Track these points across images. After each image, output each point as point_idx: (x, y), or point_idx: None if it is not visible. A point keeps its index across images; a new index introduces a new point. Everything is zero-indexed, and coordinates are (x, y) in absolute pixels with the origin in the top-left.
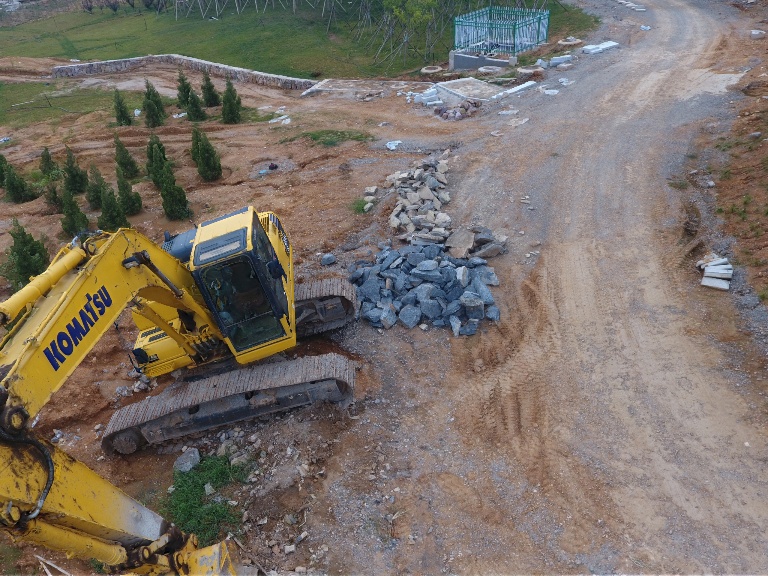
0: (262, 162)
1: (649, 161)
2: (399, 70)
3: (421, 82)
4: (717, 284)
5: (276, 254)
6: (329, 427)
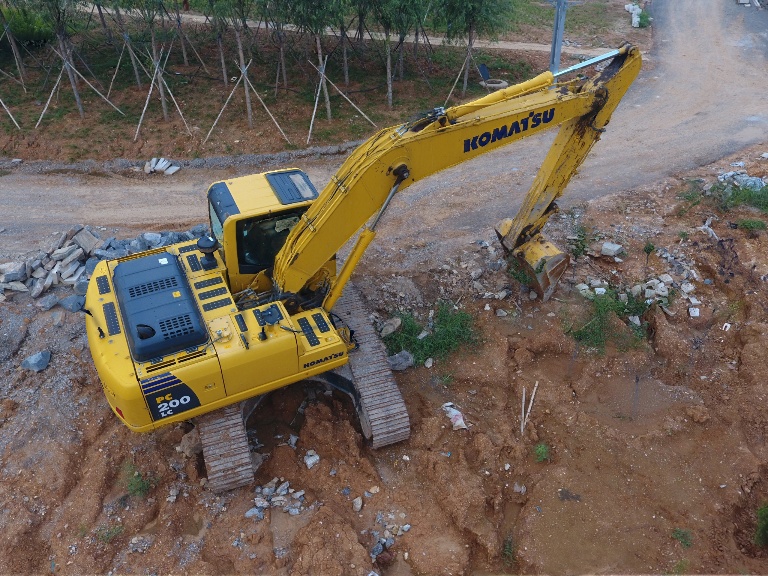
0: None
1: None
2: None
3: None
4: (175, 169)
5: None
6: None
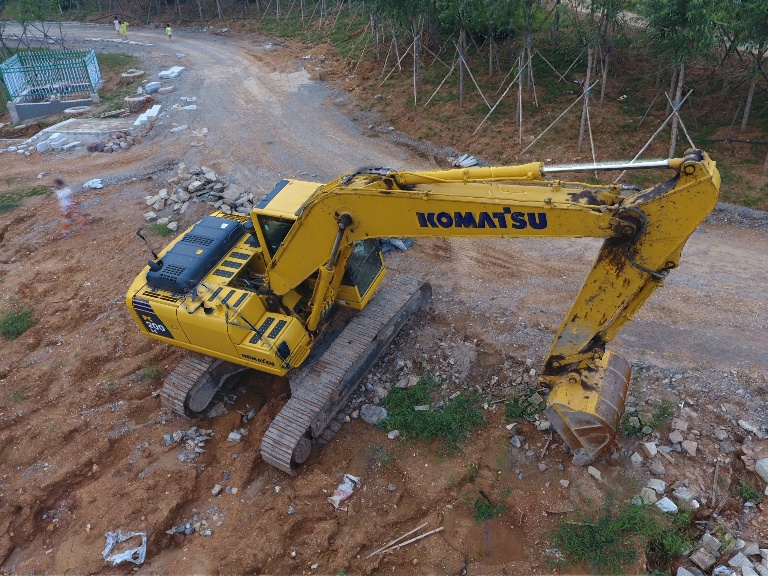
0: None
1: (336, 129)
2: None
3: None
4: None
5: None
6: (437, 323)
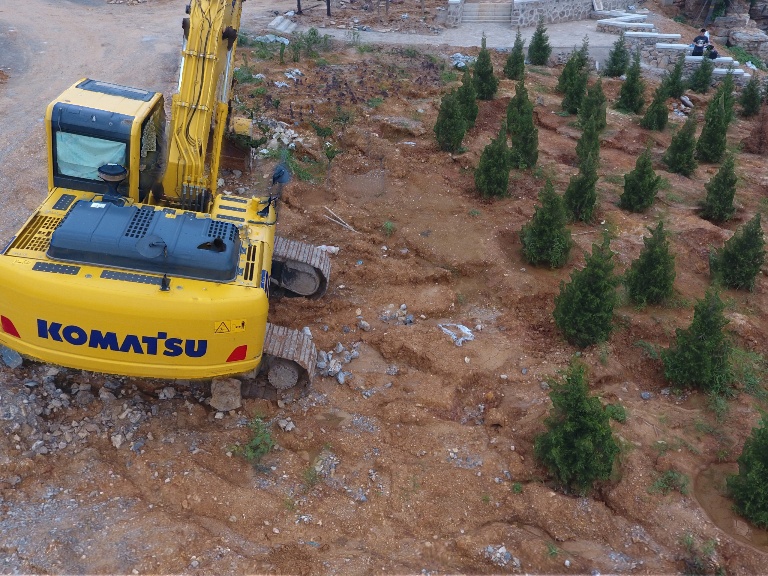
0: None
1: None
2: None
3: None
4: None
5: None
6: None
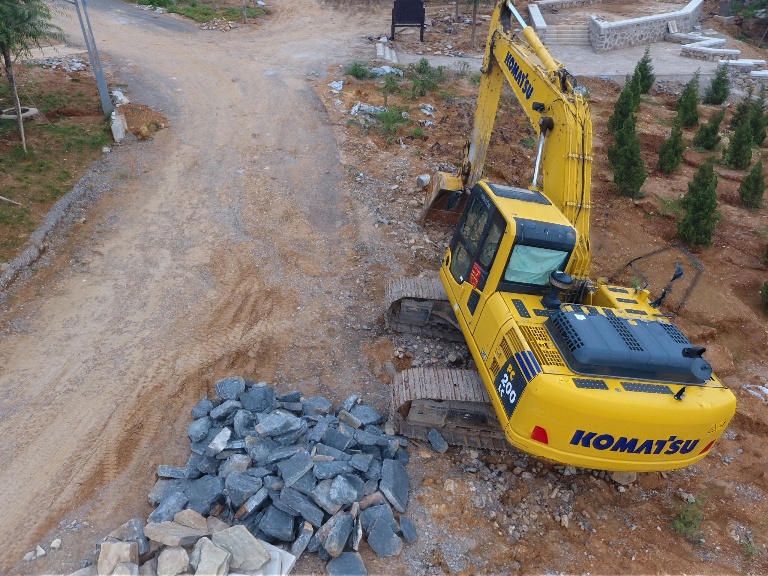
0: None
1: None
2: None
3: None
4: None
5: (486, 289)
6: None
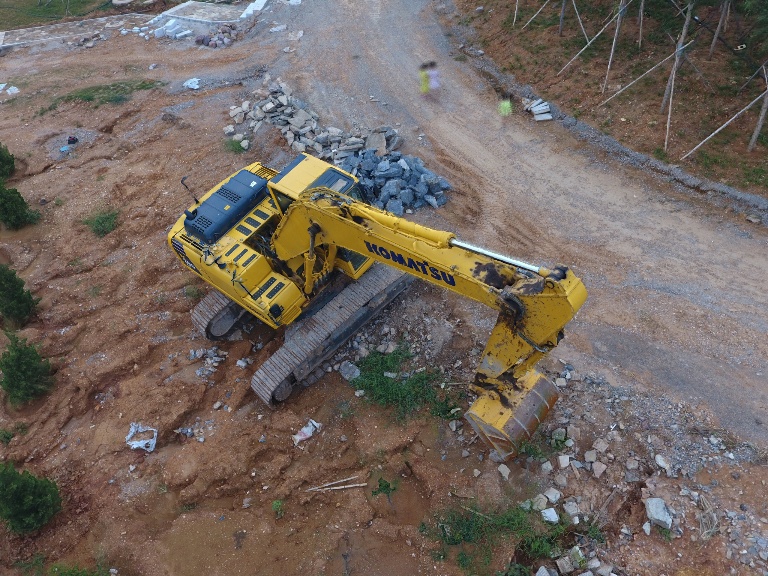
0: (50, 140)
1: (426, 45)
2: (80, 6)
3: (122, 15)
4: (545, 117)
5: None
6: (431, 296)
